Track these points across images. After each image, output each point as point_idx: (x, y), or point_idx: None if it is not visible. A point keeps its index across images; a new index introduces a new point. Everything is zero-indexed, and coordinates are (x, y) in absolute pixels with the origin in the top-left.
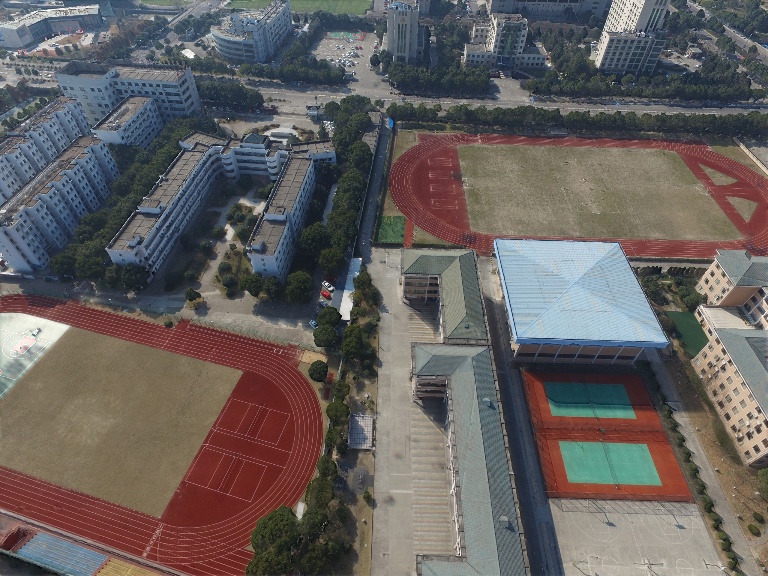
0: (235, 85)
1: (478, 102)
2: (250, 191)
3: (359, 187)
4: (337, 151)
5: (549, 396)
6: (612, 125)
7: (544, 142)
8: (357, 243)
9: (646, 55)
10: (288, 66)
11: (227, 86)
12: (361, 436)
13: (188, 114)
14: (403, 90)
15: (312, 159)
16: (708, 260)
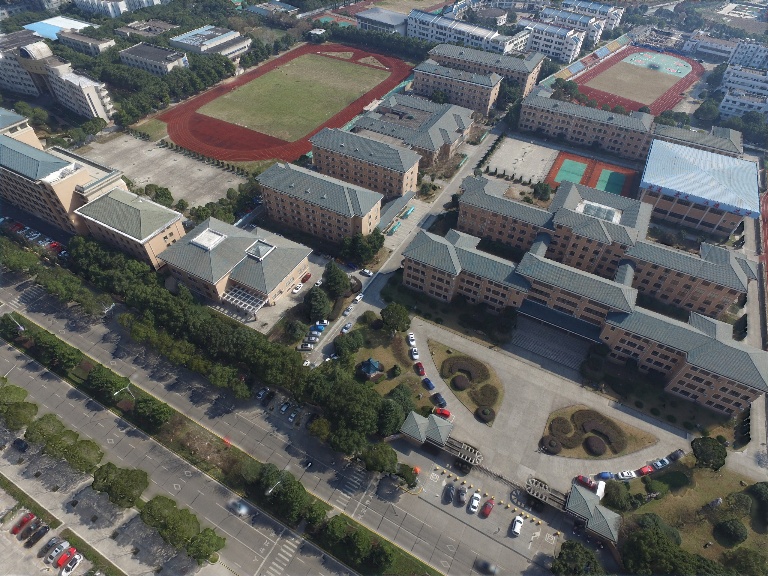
0: None
1: None
2: None
3: None
4: None
5: (616, 172)
6: None
7: None
8: (763, 152)
9: None
10: None
11: None
12: None
13: None
14: None
15: None
16: (765, 319)
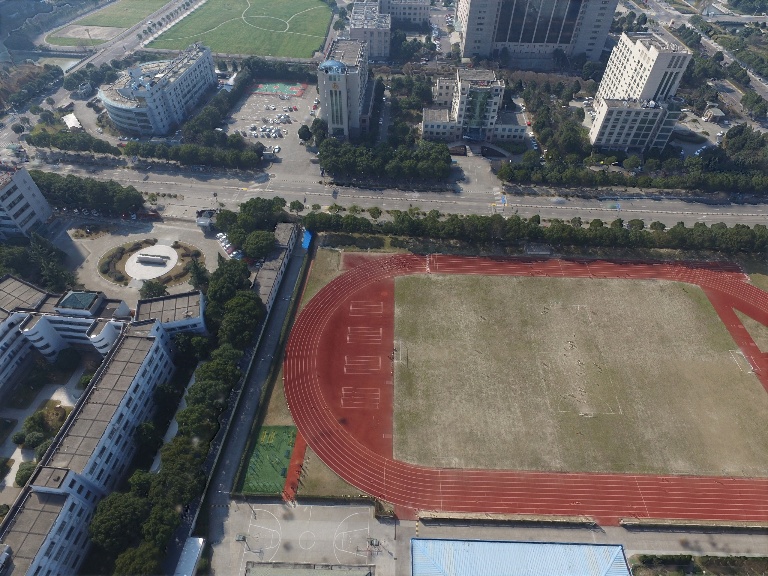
0: (97, 185)
1: (433, 197)
2: (76, 373)
3: (221, 390)
4: (206, 311)
5: None
6: None
7: (517, 269)
8: (209, 492)
9: (655, 128)
10: (185, 146)
11: (86, 186)
12: None
13: (23, 231)
14: (337, 177)
15: (156, 339)
16: (764, 529)
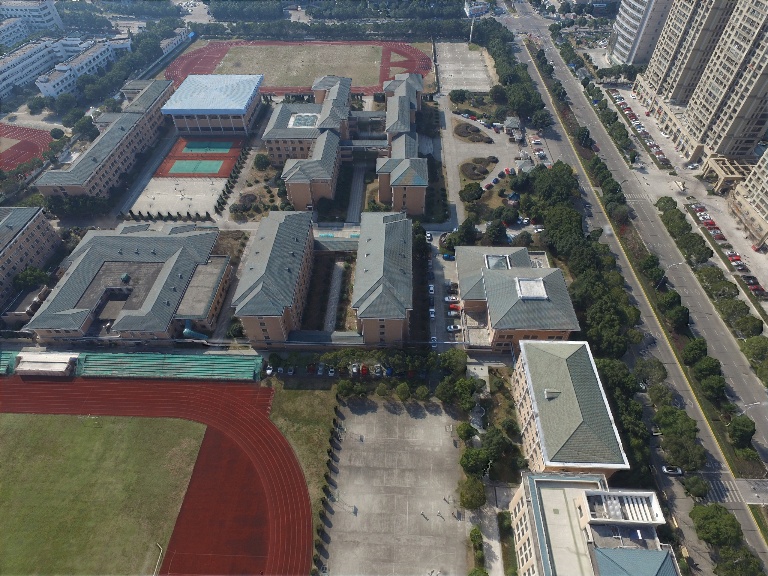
0: (87, 13)
1: None
2: None
3: (132, 60)
4: (132, 44)
5: (187, 146)
6: (348, 32)
7: (294, 43)
8: None
9: None
10: (136, 4)
11: (82, 14)
12: (69, 159)
13: None
14: (220, 19)
15: (107, 45)
16: None
